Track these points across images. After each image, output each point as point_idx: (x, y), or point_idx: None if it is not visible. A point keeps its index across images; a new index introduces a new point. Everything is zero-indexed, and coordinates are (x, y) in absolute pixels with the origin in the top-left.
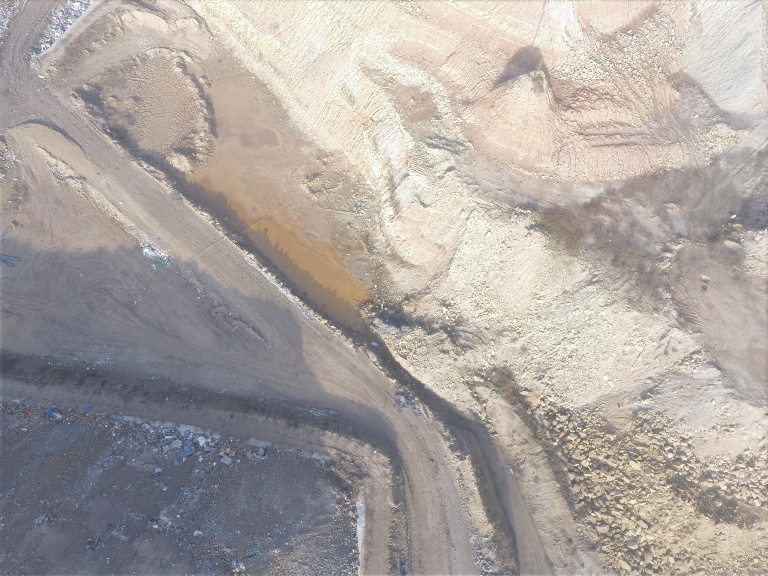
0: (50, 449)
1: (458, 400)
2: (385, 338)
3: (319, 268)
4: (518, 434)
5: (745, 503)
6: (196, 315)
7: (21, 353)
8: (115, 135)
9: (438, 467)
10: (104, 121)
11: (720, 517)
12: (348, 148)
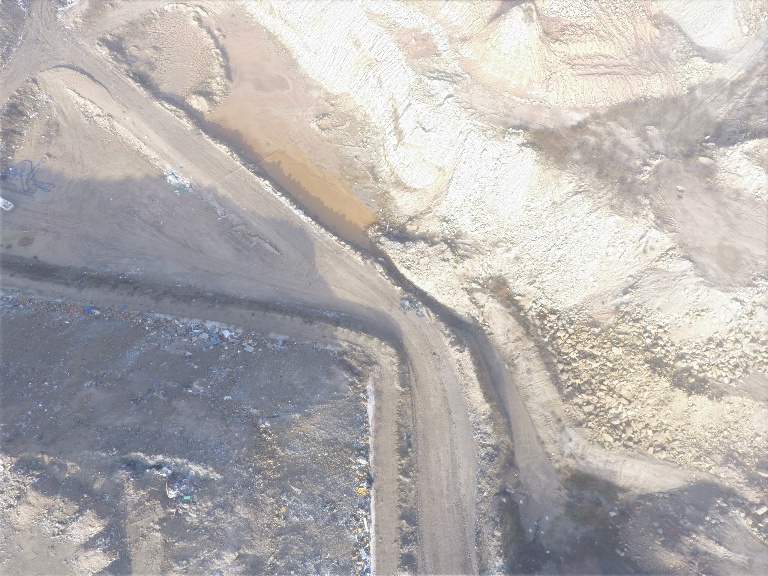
0: (92, 336)
1: (458, 305)
2: (390, 253)
3: (329, 195)
4: (512, 333)
5: (715, 381)
6: (217, 233)
7: (59, 265)
8: (138, 79)
9: (440, 359)
10: (127, 67)
11: (692, 390)
12: (354, 89)
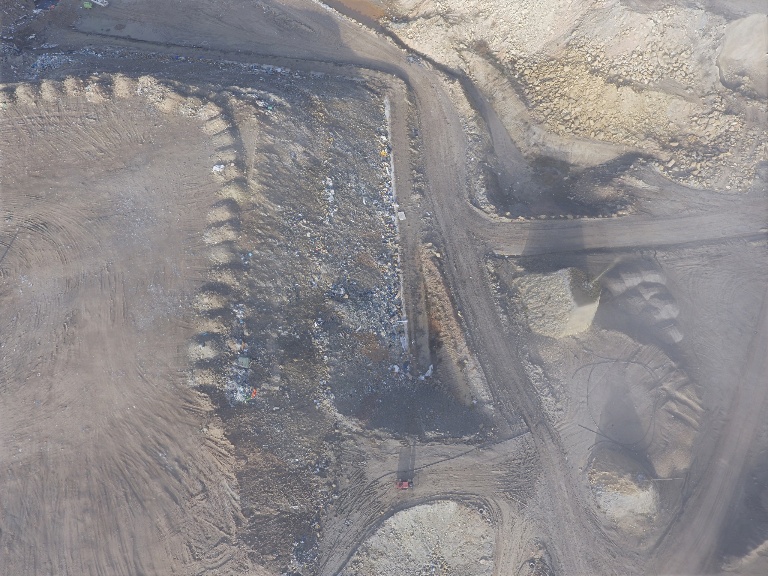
0: None
1: (450, 62)
2: (397, 32)
3: None
4: (491, 75)
5: (638, 83)
6: (264, 21)
7: None
8: None
9: (437, 90)
10: None
11: None
12: None
